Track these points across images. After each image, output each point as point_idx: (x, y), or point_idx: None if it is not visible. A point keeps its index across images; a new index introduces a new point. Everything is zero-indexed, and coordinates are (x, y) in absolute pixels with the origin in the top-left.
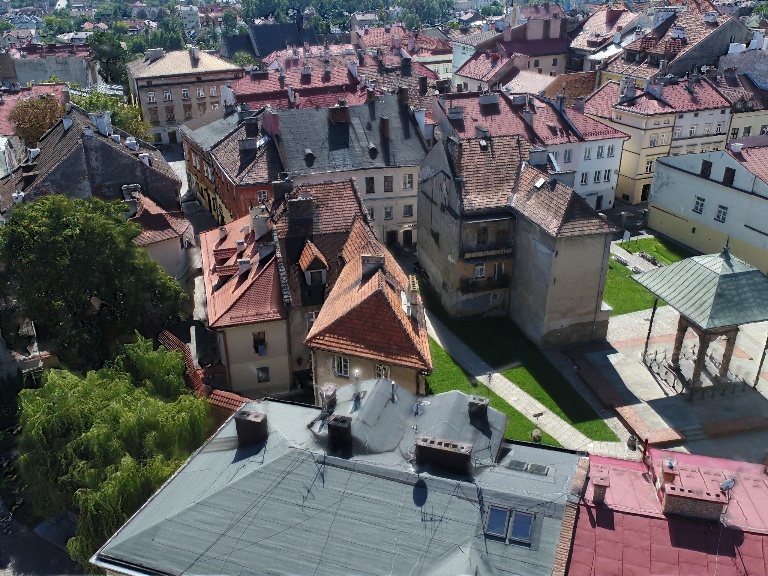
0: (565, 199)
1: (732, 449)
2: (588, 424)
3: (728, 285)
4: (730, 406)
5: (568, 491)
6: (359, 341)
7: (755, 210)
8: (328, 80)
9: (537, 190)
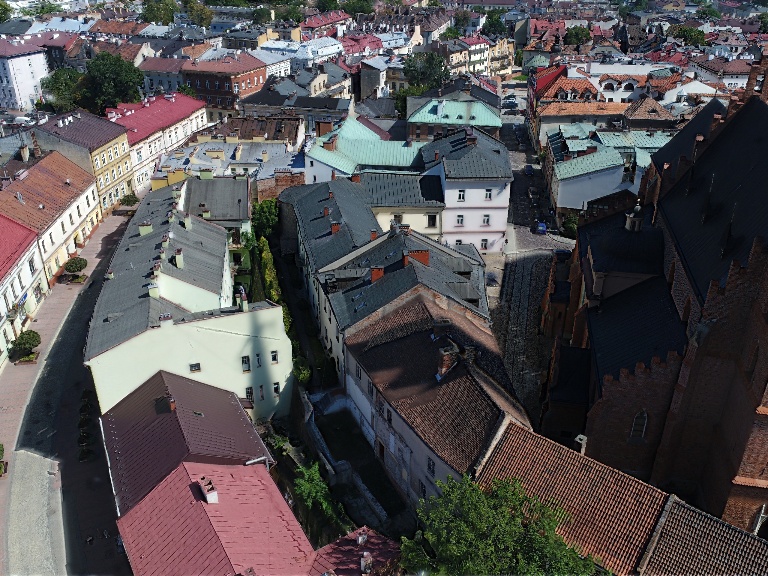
0: None
1: (513, 85)
2: None
3: None
4: None
5: None
6: None
7: None
8: None
9: None
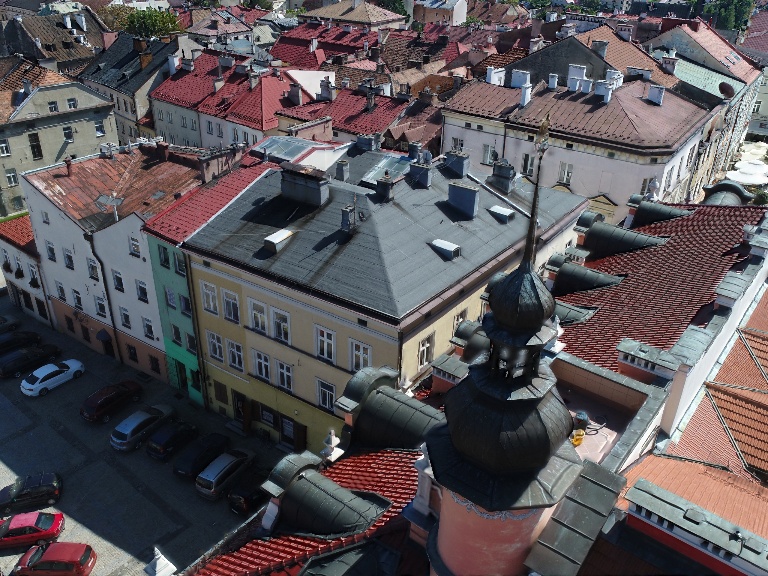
0: None
1: None
2: None
3: None
4: None
5: None
6: None
7: None
8: (356, 40)
9: None
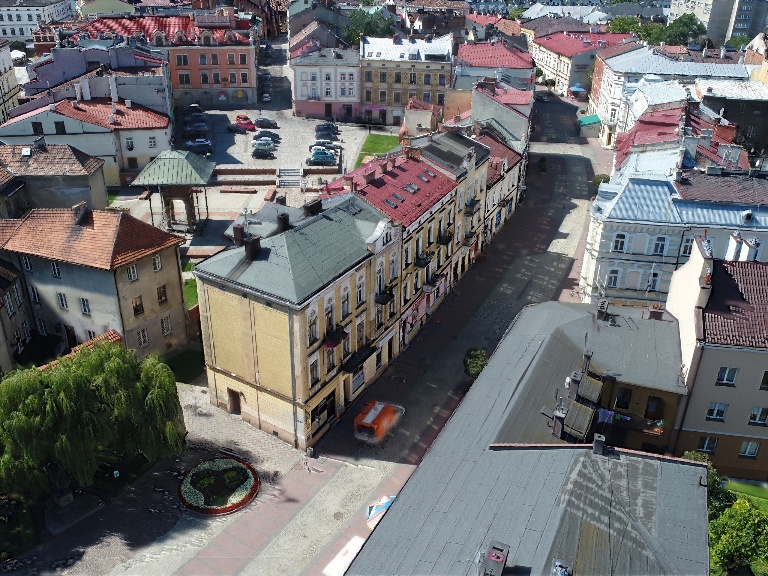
0: (67, 152)
1: None
2: (189, 267)
3: (191, 162)
4: (215, 229)
5: (350, 192)
6: (138, 248)
7: (91, 143)
8: None
9: (29, 157)
